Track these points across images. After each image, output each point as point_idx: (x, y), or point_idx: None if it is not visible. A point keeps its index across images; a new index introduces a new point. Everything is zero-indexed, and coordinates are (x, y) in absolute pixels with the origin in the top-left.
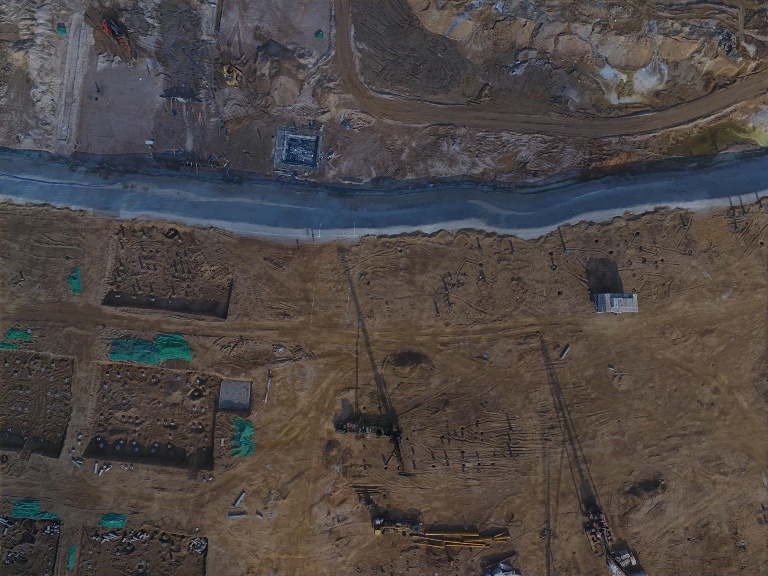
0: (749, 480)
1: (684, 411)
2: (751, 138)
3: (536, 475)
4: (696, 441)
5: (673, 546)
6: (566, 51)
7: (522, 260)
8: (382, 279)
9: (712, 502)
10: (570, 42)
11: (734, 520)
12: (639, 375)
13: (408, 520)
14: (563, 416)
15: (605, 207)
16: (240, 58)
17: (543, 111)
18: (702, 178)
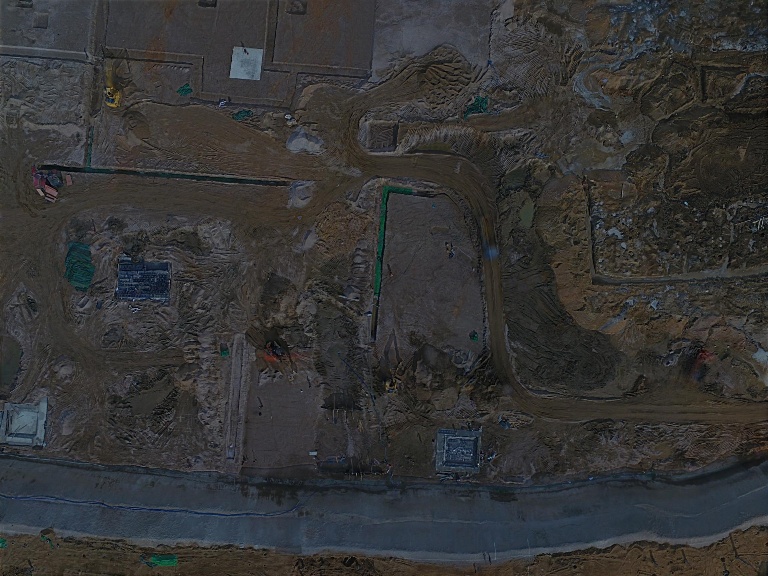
0: None
1: None
2: None
3: None
4: None
5: None
6: (719, 338)
7: (695, 568)
8: None
9: None
10: (724, 332)
11: None
12: None
13: None
14: None
15: None
16: (398, 365)
17: (699, 400)
18: None
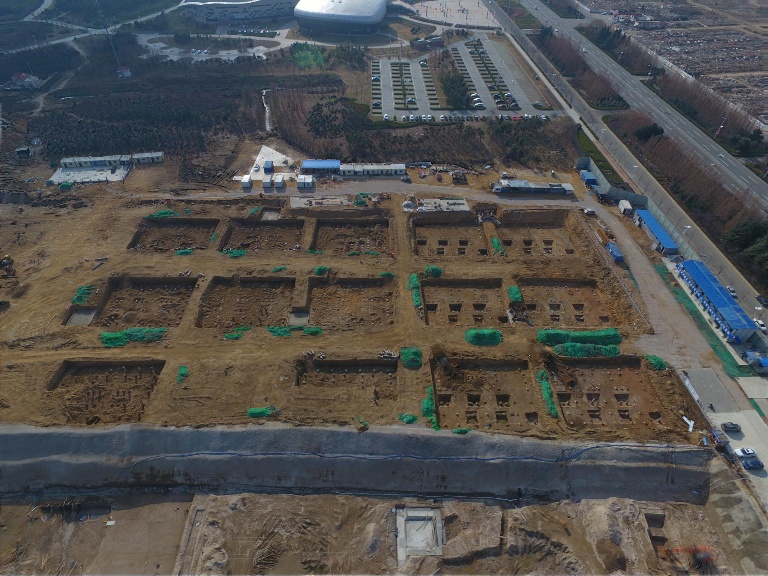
0: None
1: None
2: None
3: None
4: None
5: None
6: None
7: None
8: None
9: None
10: None
11: None
12: None
13: None
14: None
15: None
16: None
17: None
18: None
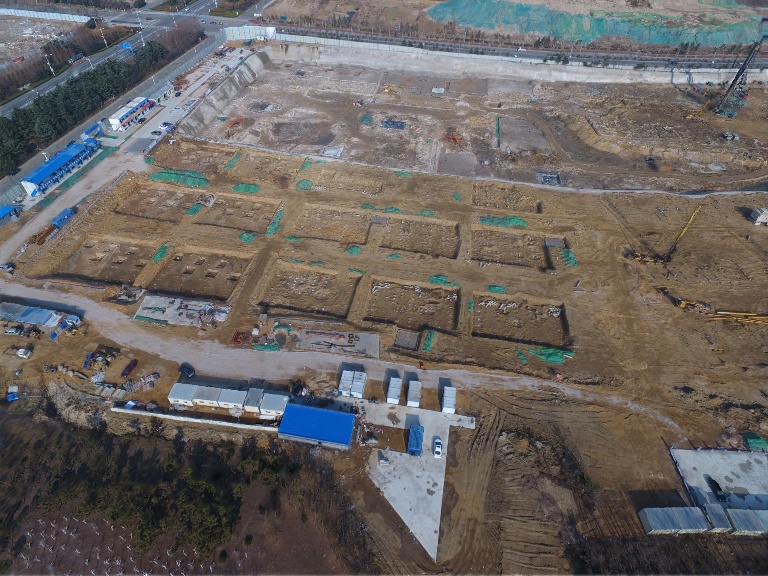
0: None
1: None
2: None
3: None
4: None
5: None
6: (669, 158)
7: None
8: None
9: None
10: (669, 154)
11: None
12: None
13: None
14: None
15: None
16: None
17: (670, 172)
18: None
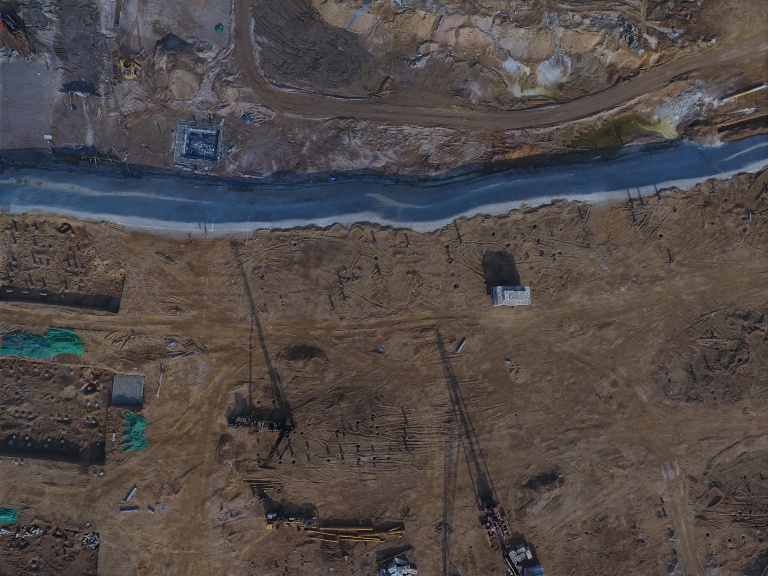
0: (648, 473)
1: (582, 404)
2: (656, 130)
3: (432, 469)
4: (594, 434)
5: (571, 540)
6: (468, 44)
7: (418, 253)
8: (276, 273)
9: (610, 496)
10: (471, 35)
11: (633, 514)
12: (536, 368)
13: (302, 514)
14: (459, 410)
15: (502, 200)
16: (139, 52)
17: (445, 104)
18: (603, 171)
